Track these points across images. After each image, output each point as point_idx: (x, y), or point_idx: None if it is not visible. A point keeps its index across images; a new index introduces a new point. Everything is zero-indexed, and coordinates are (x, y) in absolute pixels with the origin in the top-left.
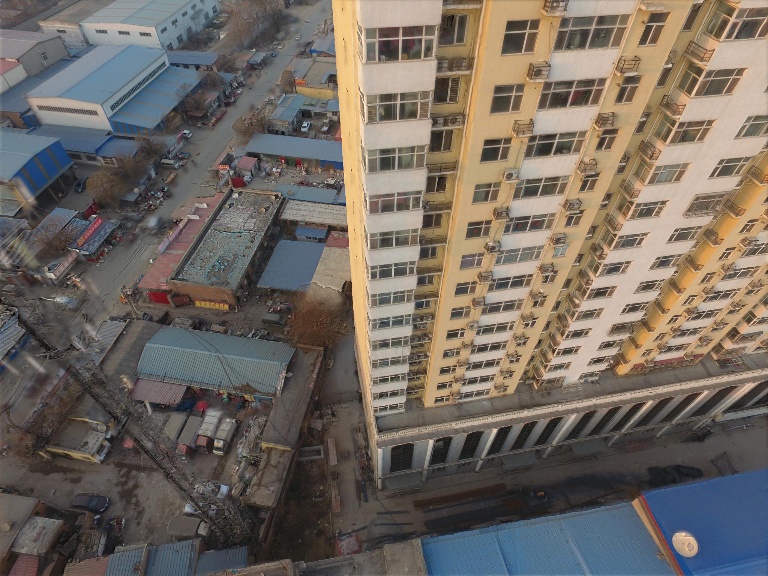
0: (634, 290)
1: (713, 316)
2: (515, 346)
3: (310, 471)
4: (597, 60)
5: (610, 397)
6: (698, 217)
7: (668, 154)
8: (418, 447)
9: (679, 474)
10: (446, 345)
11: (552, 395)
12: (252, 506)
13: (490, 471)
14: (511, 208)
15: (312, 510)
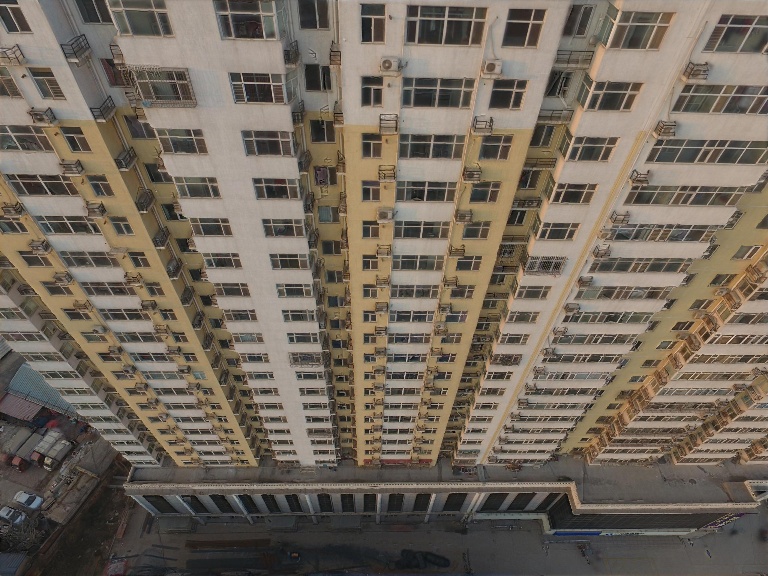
0: (302, 407)
1: (411, 433)
2: (224, 433)
3: (113, 498)
4: (109, 273)
5: (335, 485)
6: (302, 367)
7: (232, 326)
8: (170, 498)
9: (425, 561)
10: (155, 426)
11: (290, 474)
12: (52, 520)
13: (263, 526)
14: (125, 347)
15: (100, 532)
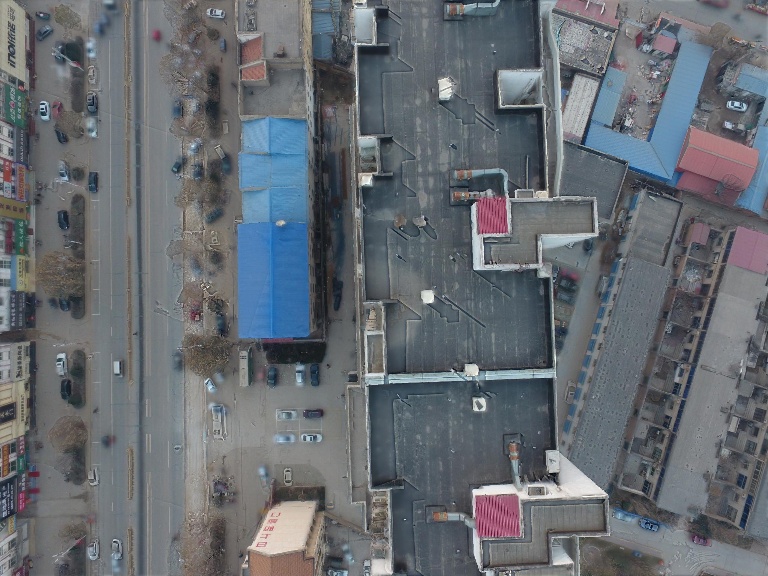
0: None
1: None
2: None
3: None
4: None
5: None
6: None
7: None
8: None
9: (336, 295)
10: None
11: None
12: None
13: None
14: None
15: (348, 94)
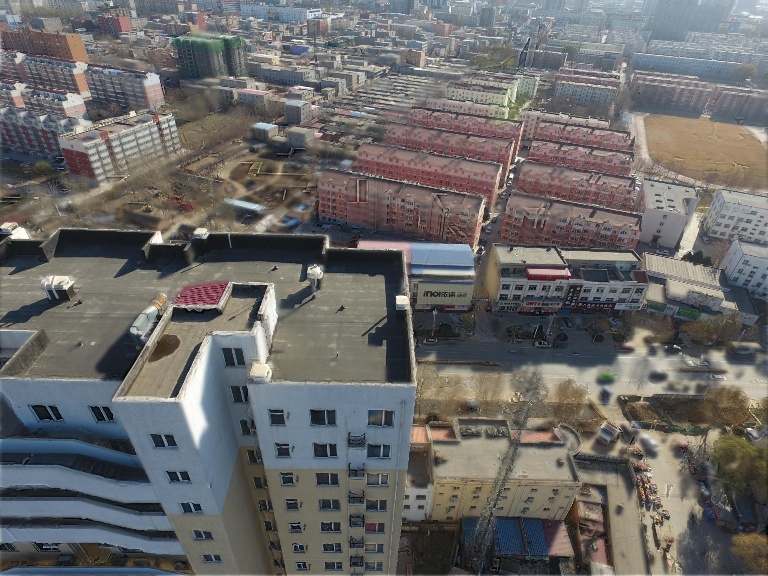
0: None
1: None
2: None
3: None
4: None
5: None
6: None
7: None
8: None
9: None
10: None
11: None
12: None
13: None
14: None
15: (426, 569)
